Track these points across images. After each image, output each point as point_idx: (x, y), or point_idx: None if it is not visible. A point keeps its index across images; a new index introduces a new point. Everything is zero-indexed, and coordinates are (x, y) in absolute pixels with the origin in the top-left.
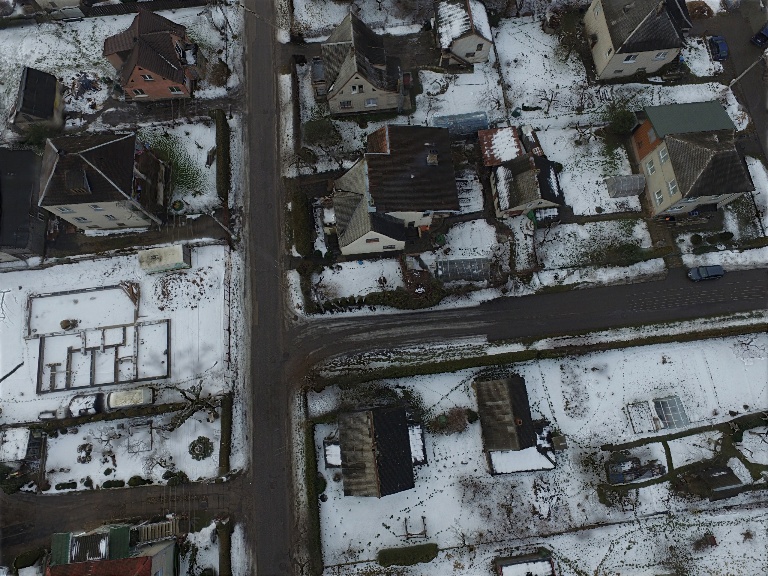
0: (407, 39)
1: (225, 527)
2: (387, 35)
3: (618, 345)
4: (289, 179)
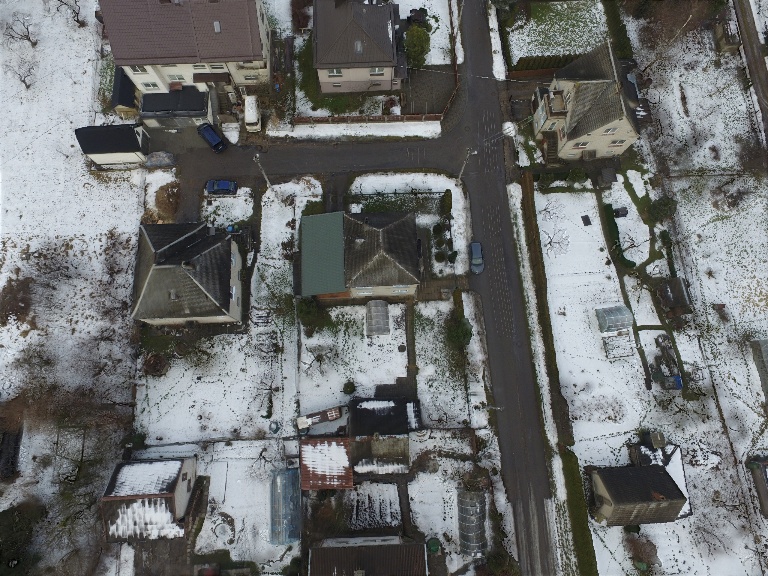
0: (142, 568)
1: None
2: None
3: None
4: None
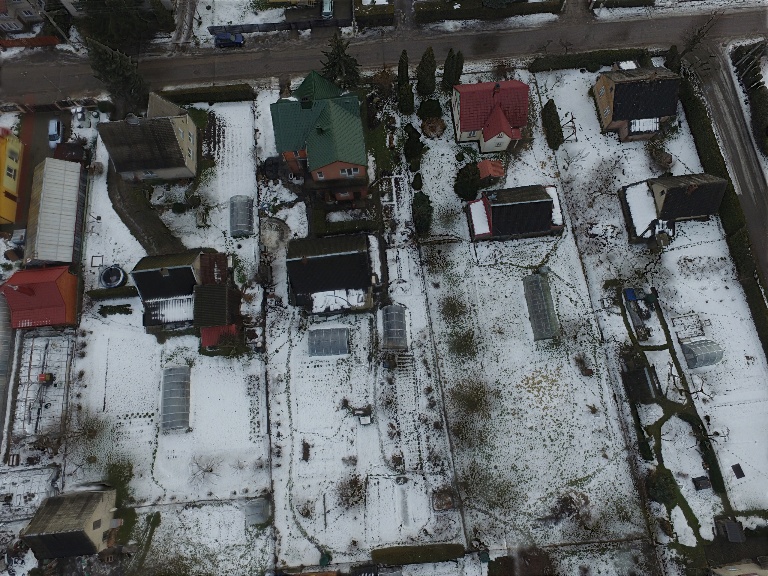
0: None
1: (561, 4)
2: None
3: (763, 305)
4: None
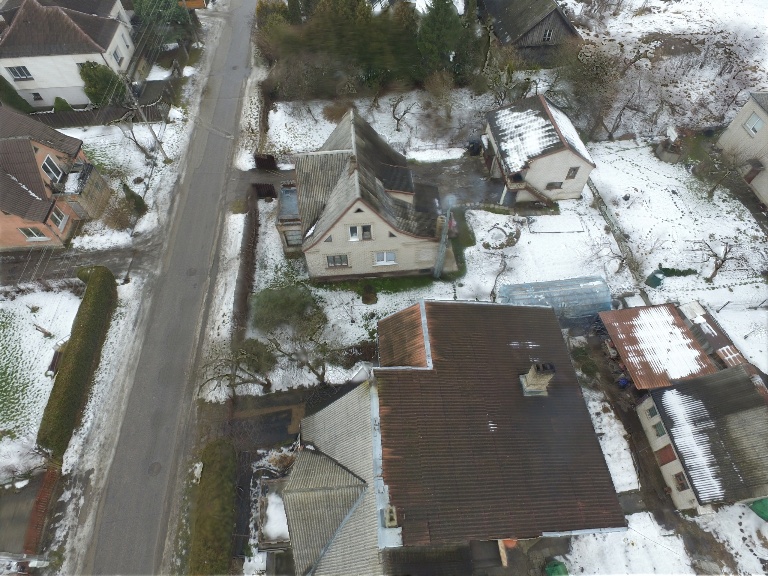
0: (442, 167)
1: None
2: (410, 161)
3: None
4: (210, 405)
